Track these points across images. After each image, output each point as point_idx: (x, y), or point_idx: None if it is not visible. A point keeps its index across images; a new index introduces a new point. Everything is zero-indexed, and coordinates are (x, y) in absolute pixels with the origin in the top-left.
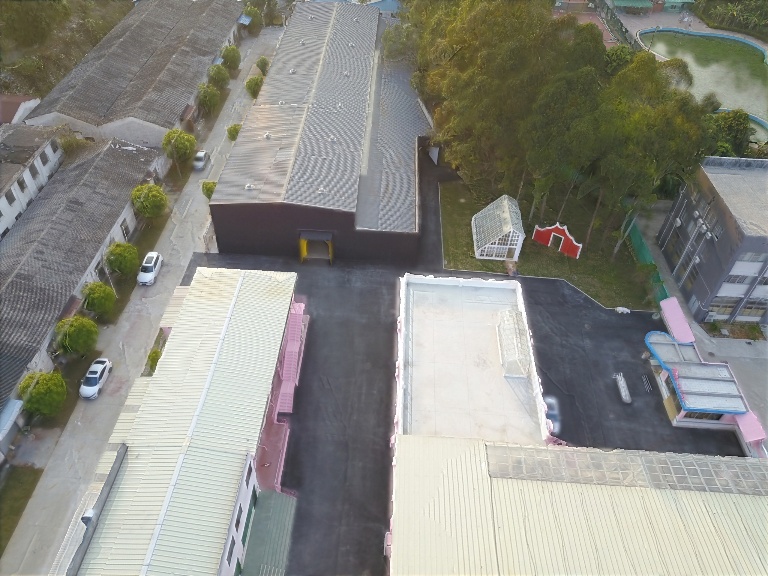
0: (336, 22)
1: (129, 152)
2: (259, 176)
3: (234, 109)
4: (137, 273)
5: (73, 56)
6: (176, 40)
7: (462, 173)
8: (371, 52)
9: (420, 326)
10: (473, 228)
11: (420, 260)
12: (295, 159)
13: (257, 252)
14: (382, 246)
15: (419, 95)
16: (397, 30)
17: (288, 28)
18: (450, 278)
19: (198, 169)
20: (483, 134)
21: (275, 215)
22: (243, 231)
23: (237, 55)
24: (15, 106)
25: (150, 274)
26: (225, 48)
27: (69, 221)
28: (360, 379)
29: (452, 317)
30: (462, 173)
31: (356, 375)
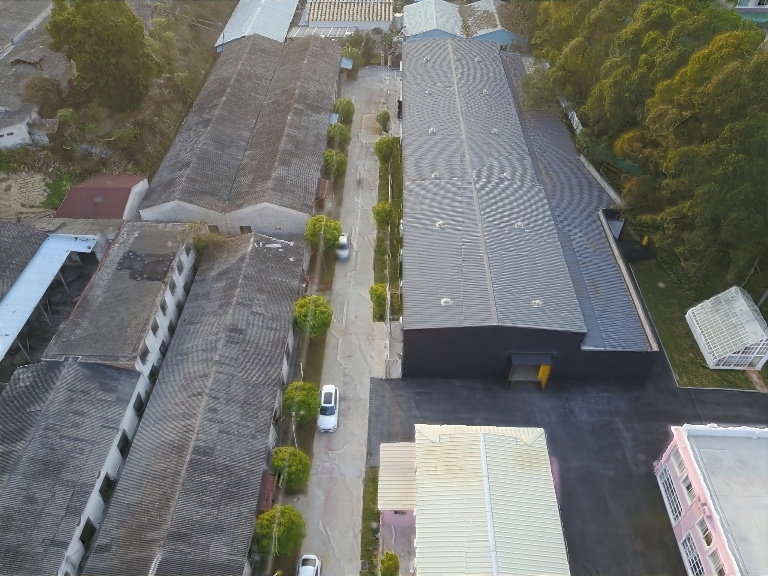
0: (458, 64)
1: (275, 251)
2: (452, 285)
3: (359, 174)
4: (317, 417)
5: (166, 117)
6: (283, 95)
7: (690, 265)
8: (510, 100)
9: (731, 507)
10: (693, 326)
11: (646, 376)
12: (488, 258)
13: (449, 376)
14: (608, 366)
15: (588, 155)
16: (539, 73)
17: (405, 74)
18: (742, 428)
19: (343, 259)
20: (736, 225)
21: (483, 338)
22: (438, 355)
23: (352, 109)
24: (125, 193)
25: (332, 417)
26: (339, 102)
27: (234, 359)
28: (637, 567)
29: (766, 490)
30: (690, 265)
31: (630, 561)
